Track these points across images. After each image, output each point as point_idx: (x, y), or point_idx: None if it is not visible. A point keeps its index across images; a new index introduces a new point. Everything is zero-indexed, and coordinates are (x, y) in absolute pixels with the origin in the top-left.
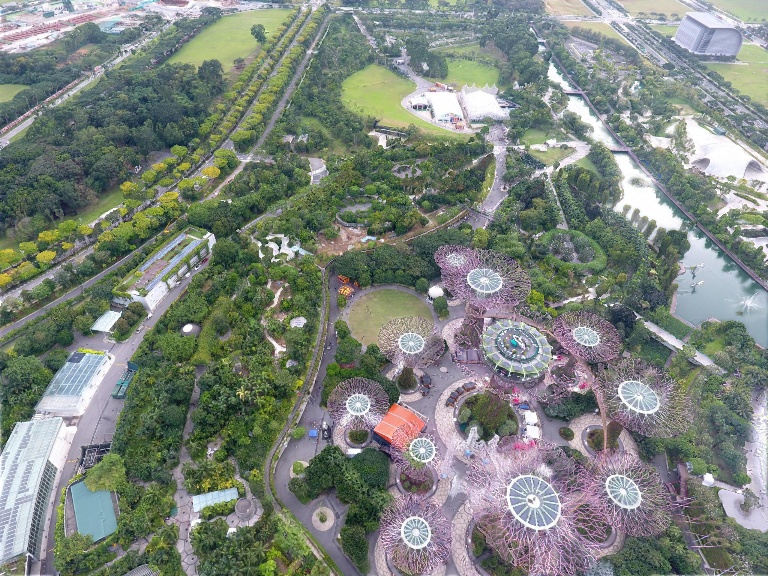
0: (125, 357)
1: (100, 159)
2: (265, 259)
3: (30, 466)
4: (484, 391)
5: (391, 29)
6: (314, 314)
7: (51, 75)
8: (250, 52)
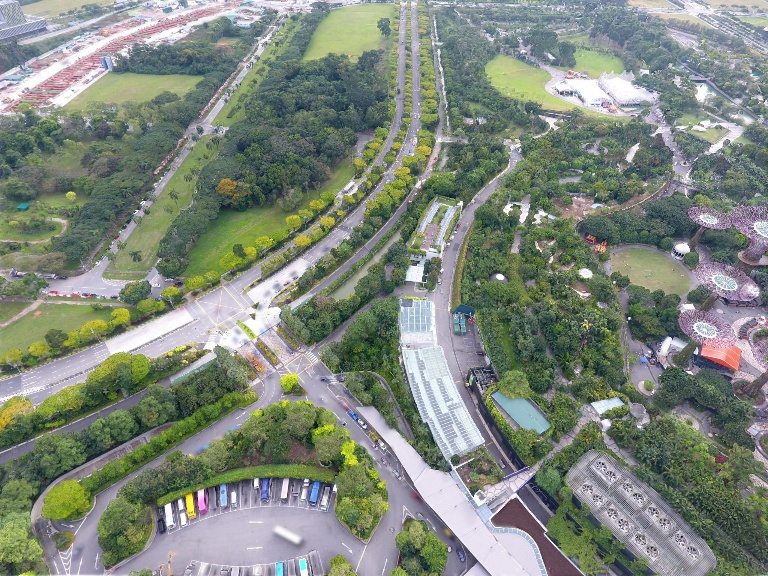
0: (442, 303)
1: (328, 138)
2: (530, 221)
3: (441, 382)
4: None
5: (496, 22)
6: (597, 266)
7: (214, 66)
8: (378, 44)
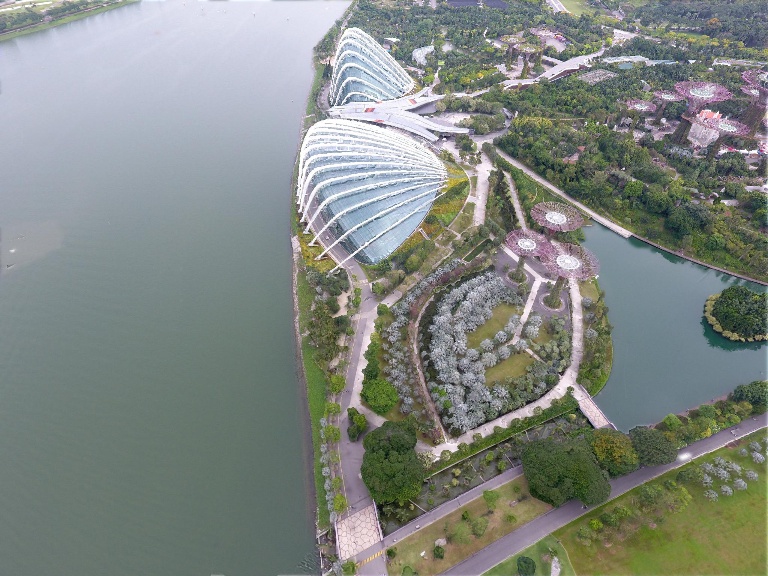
0: None
1: None
2: None
3: None
4: None
5: None
6: None
7: None
8: None
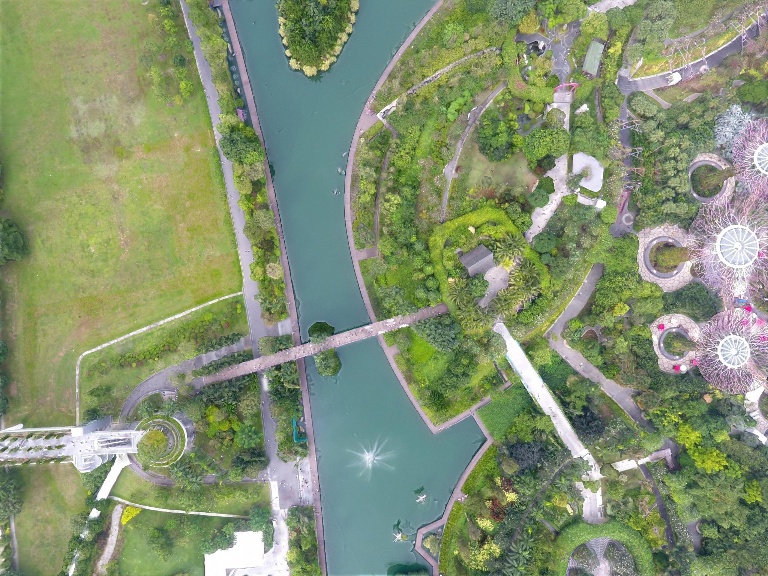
0: None
1: None
2: None
3: None
4: None
5: None
6: None
7: None
8: None
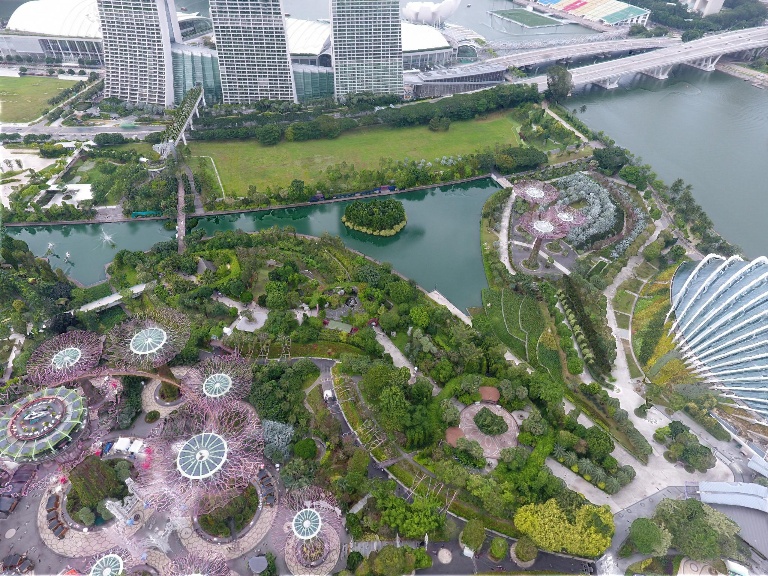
0: None
1: None
2: None
3: None
4: (68, 486)
5: None
6: None
7: None
8: None
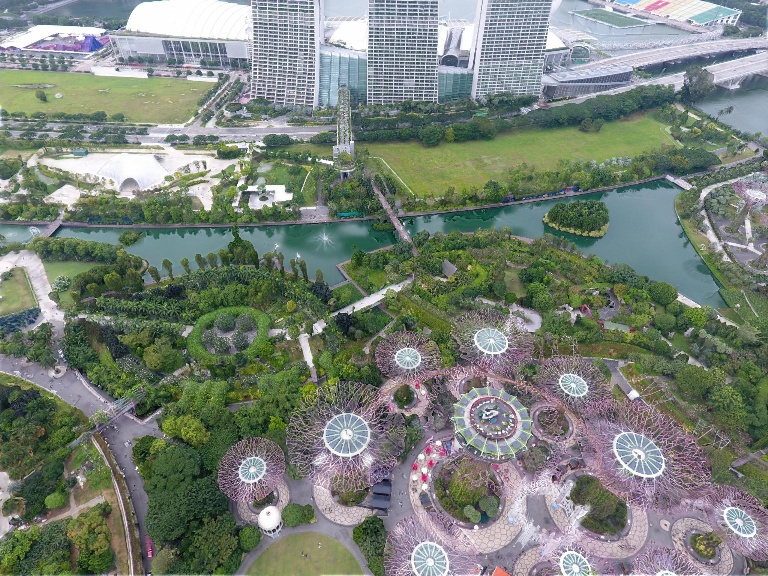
0: None
1: None
2: None
3: None
4: None
5: None
6: None
7: None
8: None
